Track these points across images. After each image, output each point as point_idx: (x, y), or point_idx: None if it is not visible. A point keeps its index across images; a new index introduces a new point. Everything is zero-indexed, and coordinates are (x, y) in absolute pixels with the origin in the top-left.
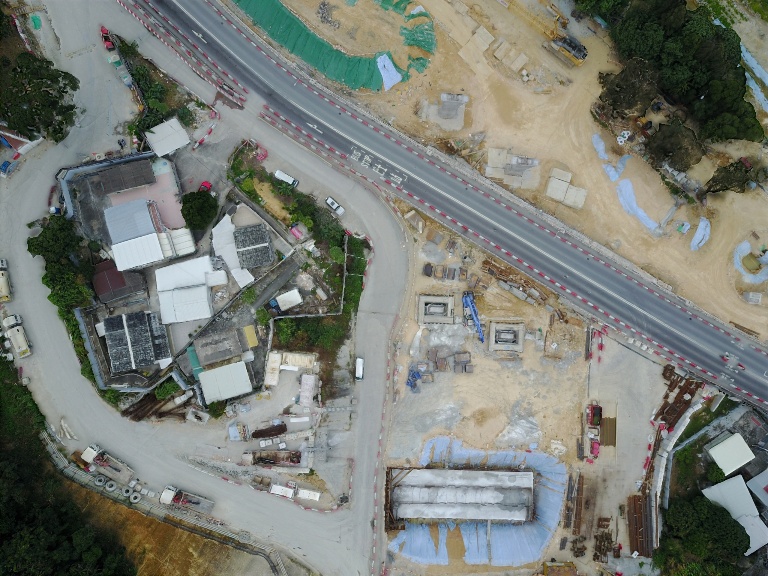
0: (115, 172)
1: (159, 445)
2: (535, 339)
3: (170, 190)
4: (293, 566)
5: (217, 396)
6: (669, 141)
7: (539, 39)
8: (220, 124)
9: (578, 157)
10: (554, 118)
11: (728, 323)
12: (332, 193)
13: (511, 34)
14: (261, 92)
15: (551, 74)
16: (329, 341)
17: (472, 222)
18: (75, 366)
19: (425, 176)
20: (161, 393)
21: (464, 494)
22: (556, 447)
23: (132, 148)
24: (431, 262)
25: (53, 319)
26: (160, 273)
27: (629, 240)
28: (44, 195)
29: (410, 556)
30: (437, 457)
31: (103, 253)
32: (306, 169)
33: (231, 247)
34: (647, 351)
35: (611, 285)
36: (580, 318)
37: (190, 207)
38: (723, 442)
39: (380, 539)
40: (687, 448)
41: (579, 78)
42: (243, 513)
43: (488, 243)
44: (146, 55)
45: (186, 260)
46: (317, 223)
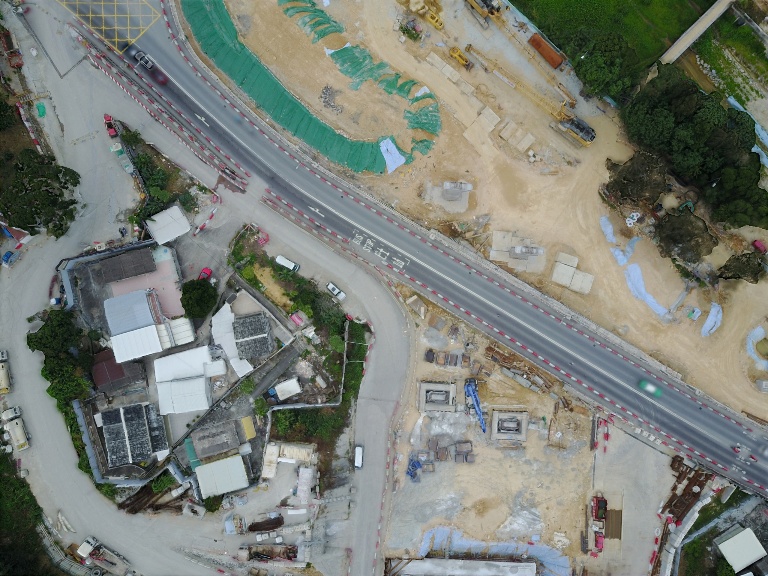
0: (115, 261)
1: (156, 537)
2: (539, 429)
3: (170, 277)
4: None
5: (214, 491)
6: (678, 233)
7: (546, 119)
8: (222, 208)
9: (585, 240)
10: (561, 200)
11: (740, 413)
12: (333, 277)
13: (517, 114)
14: (263, 175)
15: (558, 154)
16: (328, 431)
17: (475, 307)
18: (73, 458)
19: (428, 260)
20: (158, 487)
21: None
22: (559, 540)
23: (133, 236)
24: (433, 348)
25: (52, 410)
26: (159, 363)
27: (637, 326)
28: (45, 284)
29: None
30: (437, 545)
31: (103, 341)
32: (307, 253)
33: (230, 336)
34: (655, 442)
35: (618, 373)
36: (586, 406)
37: (189, 298)
38: (733, 537)
39: None
40: (696, 541)
41: (587, 158)
42: None
43: (491, 329)
44: (148, 140)
45: (185, 348)
46: (317, 310)
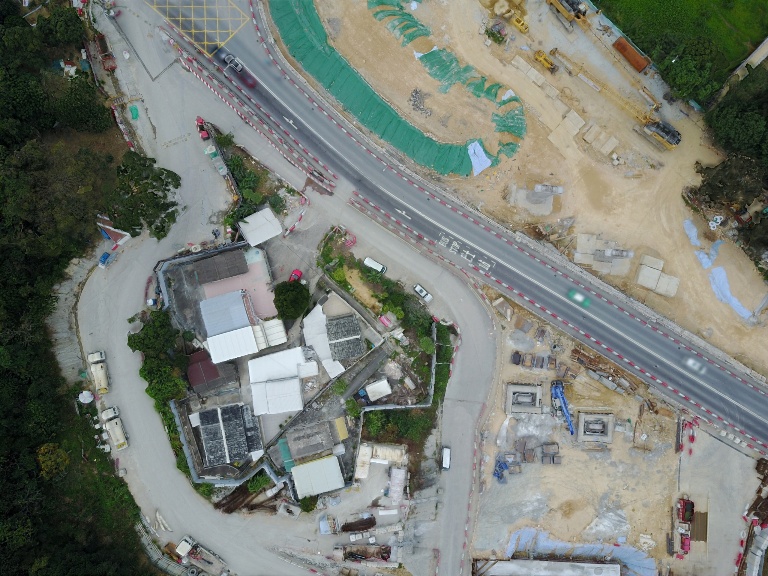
0: (210, 263)
1: (250, 537)
2: (625, 431)
3: (262, 279)
4: None
5: (309, 491)
6: None
7: (630, 122)
8: (309, 210)
9: (669, 243)
10: (645, 203)
11: None
12: (420, 279)
13: (601, 117)
14: (350, 178)
15: (642, 157)
16: (418, 432)
17: (561, 310)
18: (170, 458)
19: (513, 263)
20: (254, 487)
21: None
22: (645, 541)
23: (226, 237)
24: (519, 350)
25: (149, 410)
26: (253, 364)
27: (722, 329)
28: (140, 285)
29: None
30: (521, 547)
31: (196, 342)
32: (394, 255)
33: (322, 337)
34: (740, 444)
35: (703, 375)
36: (670, 409)
37: (284, 299)
38: None
39: None
40: None
41: (670, 161)
42: None
43: (577, 331)
44: (239, 142)
45: (277, 349)
46: (406, 312)
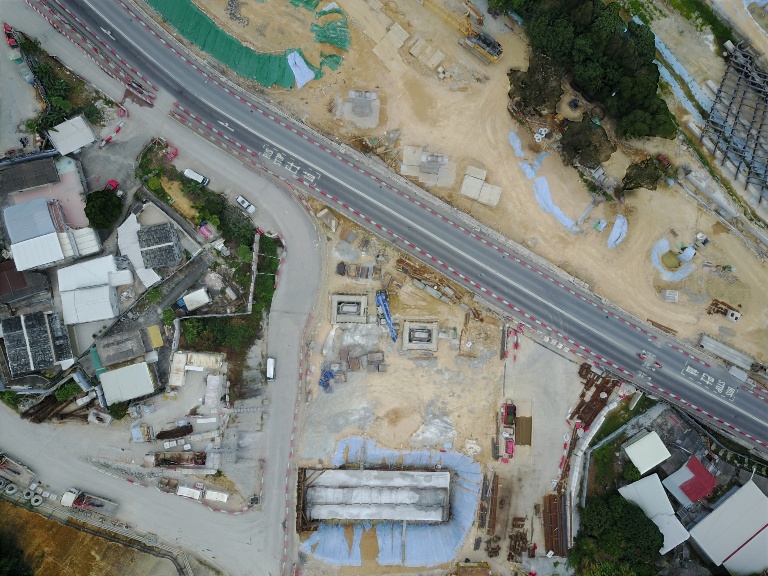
0: (16, 171)
1: (61, 447)
2: (449, 338)
3: (75, 189)
4: (201, 568)
5: (118, 397)
6: (577, 138)
7: (455, 36)
8: (129, 122)
9: (494, 155)
10: (470, 115)
11: (645, 321)
12: (244, 192)
13: (427, 31)
14: (171, 90)
15: (468, 71)
16: (237, 341)
17: (386, 220)
18: None
19: (338, 174)
20: (61, 394)
21: (379, 494)
22: (471, 447)
23: (35, 146)
24: (344, 261)
25: None
26: (62, 273)
27: (546, 238)
28: None
29: (322, 557)
30: (352, 457)
31: (6, 253)
32: (217, 167)
33: (136, 246)
34: (563, 349)
35: (527, 283)
36: (496, 317)
37: (92, 206)
38: (639, 440)
39: (291, 540)
40: (605, 447)
41: (496, 75)
42: (150, 515)
43: (402, 241)
44: (52, 52)
45: (91, 260)
46: (226, 222)
